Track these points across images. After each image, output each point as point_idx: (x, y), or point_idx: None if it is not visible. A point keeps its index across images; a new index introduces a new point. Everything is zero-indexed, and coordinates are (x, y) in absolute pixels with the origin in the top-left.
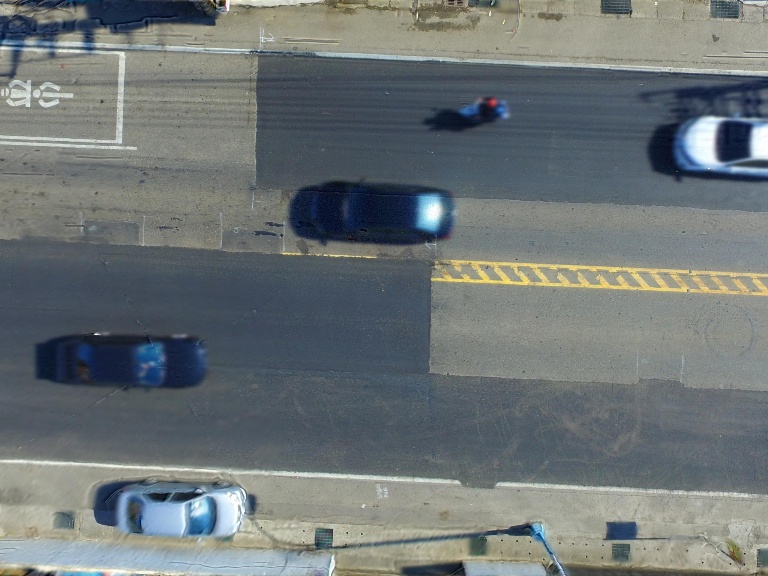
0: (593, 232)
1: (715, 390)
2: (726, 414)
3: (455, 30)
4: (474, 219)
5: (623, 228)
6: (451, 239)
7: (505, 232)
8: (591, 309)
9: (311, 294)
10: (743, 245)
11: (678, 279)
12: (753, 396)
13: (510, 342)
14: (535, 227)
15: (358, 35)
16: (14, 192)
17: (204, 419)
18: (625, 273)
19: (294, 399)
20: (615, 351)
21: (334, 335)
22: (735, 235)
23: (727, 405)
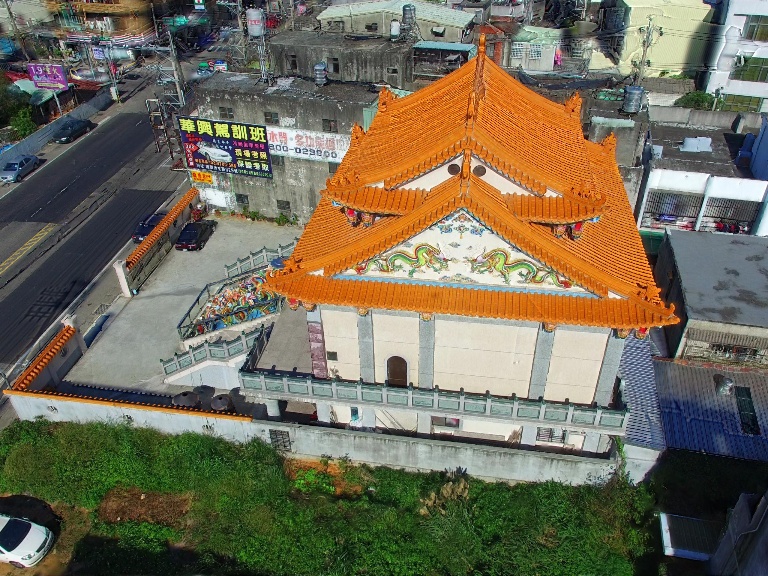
0: None
1: None
2: None
3: None
4: None
5: None
6: None
7: None
8: None
9: None
10: None
11: None
12: None
13: None
14: None
15: None
16: None
17: (48, 177)
18: None
19: None
20: None
21: None
22: None
23: None
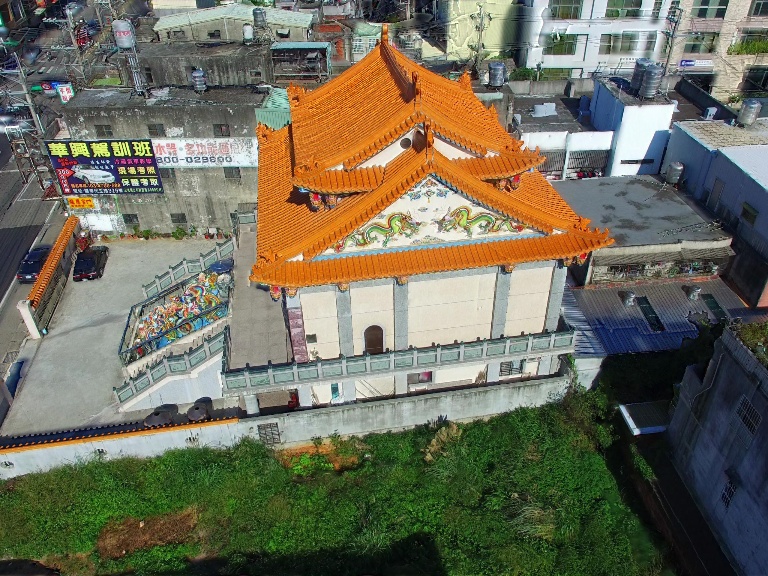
0: None
1: None
2: None
3: None
4: None
5: None
6: None
7: None
8: None
9: None
10: None
11: None
12: None
13: None
14: None
15: None
16: (8, 184)
17: None
18: None
19: None
20: None
21: None
22: None
23: None
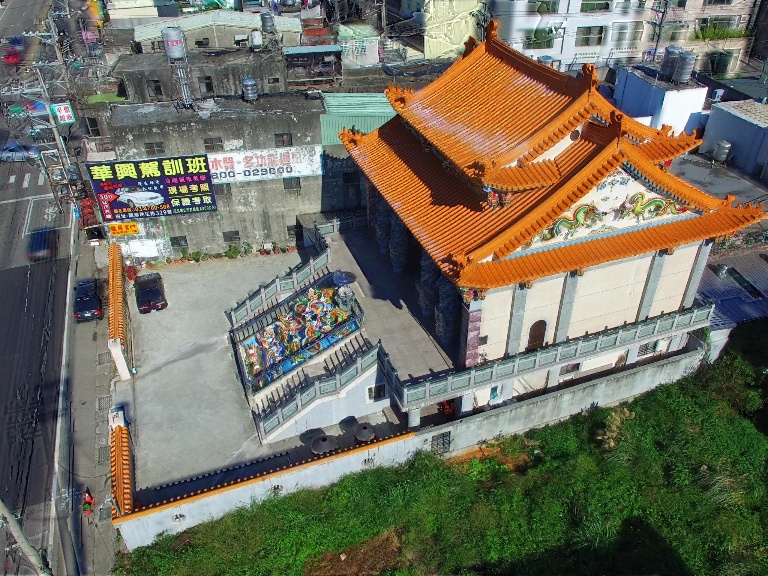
0: None
1: None
2: None
3: None
4: None
5: None
6: None
7: None
8: None
9: None
10: None
11: None
12: None
13: None
14: None
15: None
16: (5, 217)
17: None
18: None
19: None
20: None
21: None
22: None
23: None
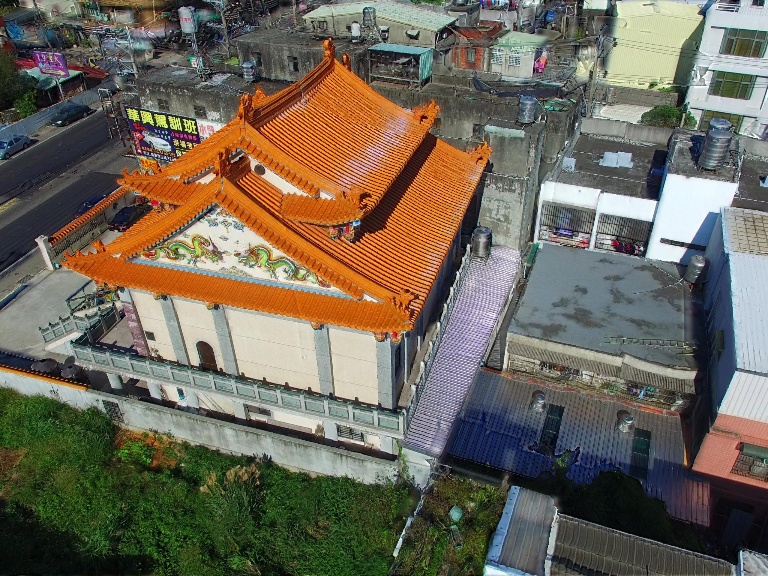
0: None
1: None
2: None
3: None
4: None
5: None
6: (24, 203)
7: (11, 214)
8: None
9: None
10: None
11: None
12: None
13: None
14: None
15: None
16: None
17: None
18: None
19: None
20: None
21: None
22: None
23: None
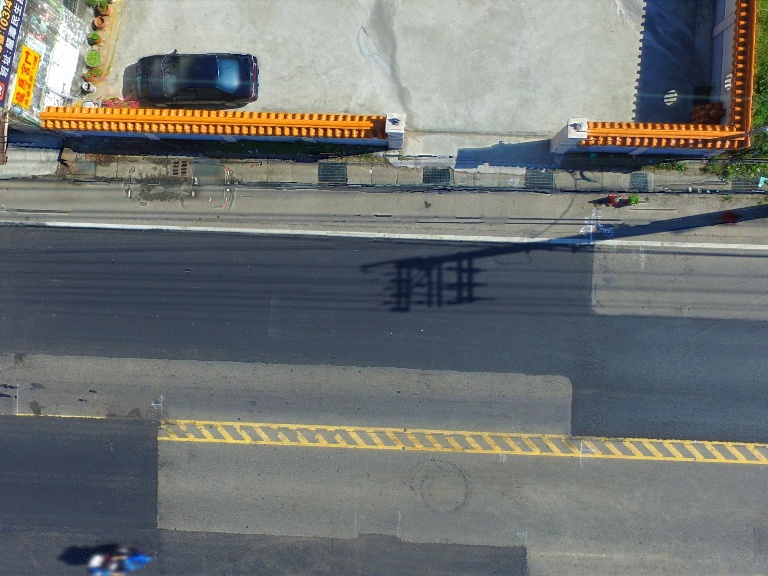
0: (312, 392)
1: (431, 544)
2: (443, 567)
3: (178, 199)
4: (198, 380)
5: (340, 388)
6: (176, 400)
7: (228, 393)
8: (311, 466)
9: (44, 453)
10: (456, 404)
11: (394, 437)
12: (468, 550)
13: (234, 498)
14: (256, 388)
15: (86, 206)
16: None
17: None
18: (343, 432)
19: (29, 553)
20: (334, 507)
21: (66, 492)
22: (448, 394)
23: (443, 559)
